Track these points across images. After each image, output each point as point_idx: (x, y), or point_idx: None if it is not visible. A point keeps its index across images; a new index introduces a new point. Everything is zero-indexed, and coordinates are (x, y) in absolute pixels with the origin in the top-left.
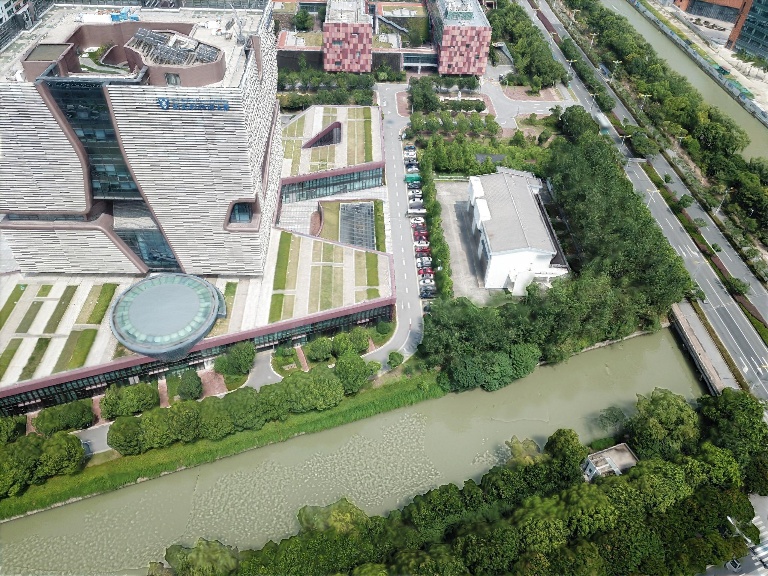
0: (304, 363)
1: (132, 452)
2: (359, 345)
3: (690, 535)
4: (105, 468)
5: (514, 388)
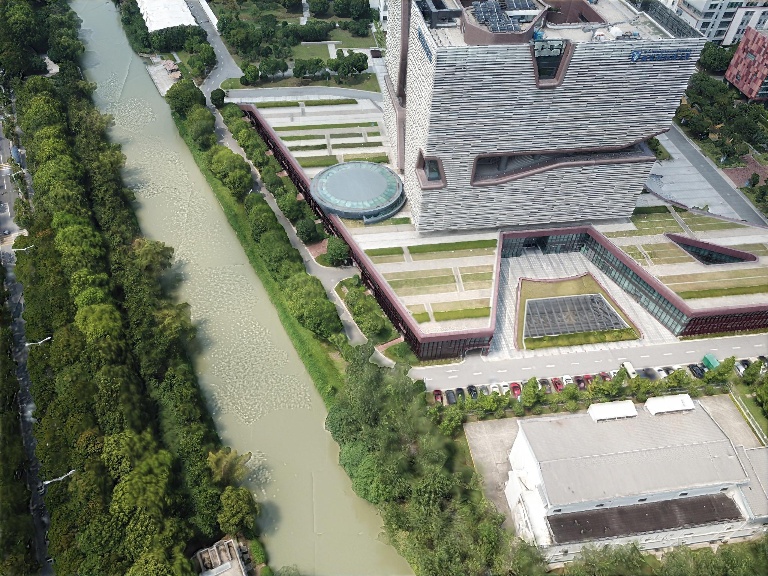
0: None
1: None
2: None
3: None
4: (242, 213)
5: None
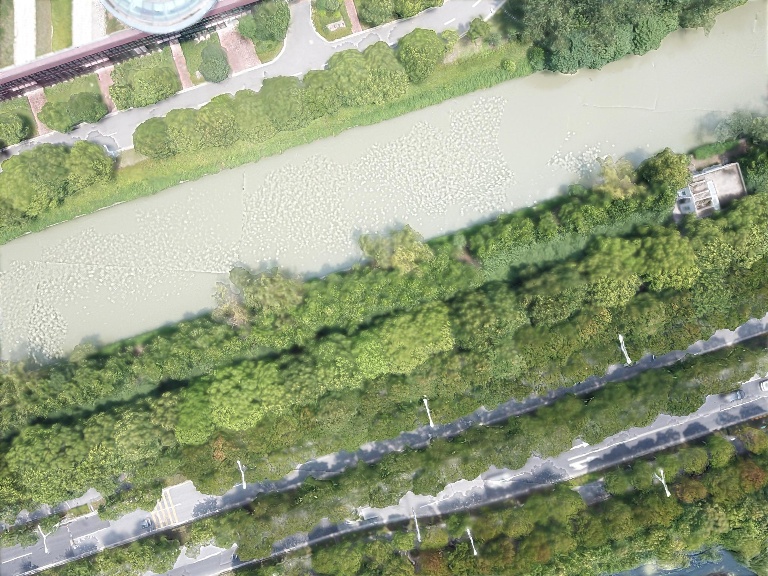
0: (355, 19)
1: (166, 157)
2: (430, 0)
3: (764, 282)
4: (141, 171)
5: (624, 60)
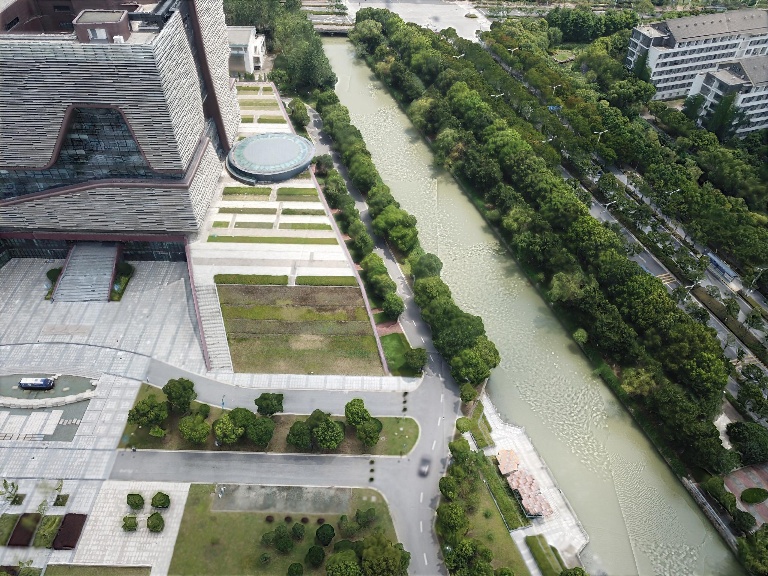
0: None
1: None
2: None
3: None
4: None
5: None
